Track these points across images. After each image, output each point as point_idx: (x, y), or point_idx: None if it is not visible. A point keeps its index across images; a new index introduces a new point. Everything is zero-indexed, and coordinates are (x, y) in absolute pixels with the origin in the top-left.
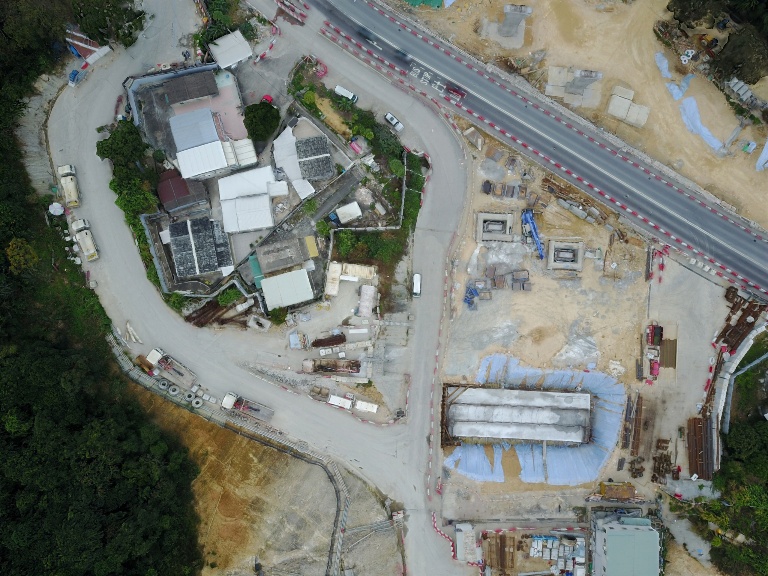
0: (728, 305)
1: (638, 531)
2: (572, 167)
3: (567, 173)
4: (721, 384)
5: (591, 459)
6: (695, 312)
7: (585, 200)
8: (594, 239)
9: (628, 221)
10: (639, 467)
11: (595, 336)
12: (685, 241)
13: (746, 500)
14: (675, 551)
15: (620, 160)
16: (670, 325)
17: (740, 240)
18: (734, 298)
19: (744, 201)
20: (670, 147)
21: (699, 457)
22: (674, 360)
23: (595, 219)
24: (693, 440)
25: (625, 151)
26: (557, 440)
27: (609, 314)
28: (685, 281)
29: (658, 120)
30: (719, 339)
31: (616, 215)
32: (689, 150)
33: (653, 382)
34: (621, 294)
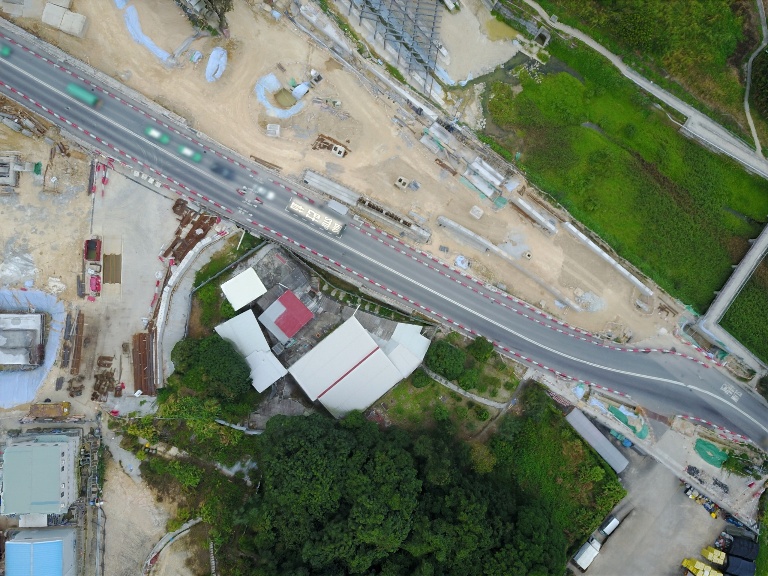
0: (178, 218)
1: (38, 446)
2: (8, 78)
3: (1, 84)
4: (162, 297)
5: (35, 381)
6: (142, 226)
7: (21, 112)
8: (34, 153)
9: (67, 133)
10: (78, 386)
11: (33, 253)
12: (131, 153)
13: (171, 411)
14: (112, 469)
15: (60, 71)
16: (115, 240)
17: (189, 151)
18: (183, 210)
19: (196, 112)
20: (116, 58)
21: (144, 373)
22: (120, 275)
23: (32, 132)
24: (138, 356)
25: (62, 61)
26: (5, 364)
27: (48, 230)
28: (132, 194)
29: (102, 30)
30: (168, 253)
31: (58, 128)
32: (137, 61)
33: (96, 298)
34: (62, 209)
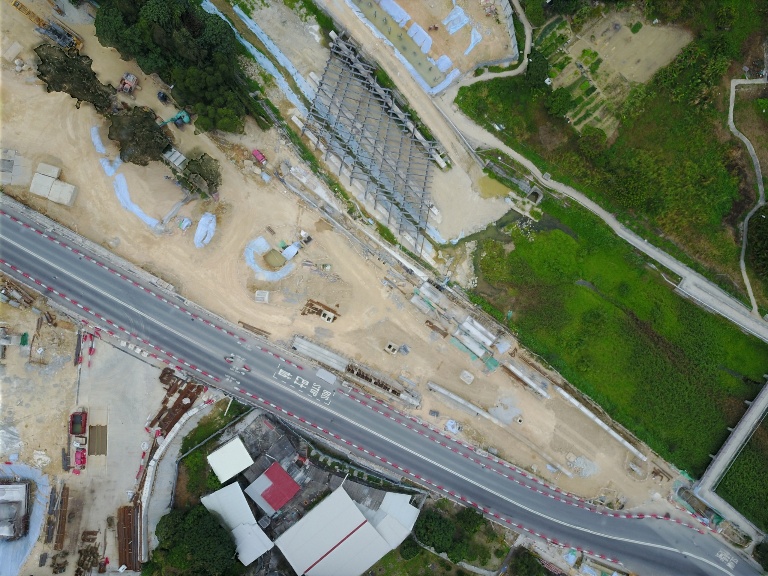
0: (165, 387)
1: None
2: None
3: None
4: (147, 471)
5: (19, 555)
6: (128, 396)
7: (8, 283)
8: (21, 323)
9: (54, 304)
10: (62, 562)
11: (18, 426)
12: (118, 322)
13: None
14: None
15: (48, 240)
16: (101, 410)
17: (177, 319)
18: (170, 379)
19: (184, 279)
20: (105, 225)
21: (129, 547)
22: (105, 447)
23: (19, 303)
24: (122, 530)
25: (50, 231)
26: None
27: (34, 402)
28: (118, 364)
29: (91, 197)
30: (154, 423)
31: (45, 297)
32: (125, 227)
33: (81, 471)
34: (48, 380)
